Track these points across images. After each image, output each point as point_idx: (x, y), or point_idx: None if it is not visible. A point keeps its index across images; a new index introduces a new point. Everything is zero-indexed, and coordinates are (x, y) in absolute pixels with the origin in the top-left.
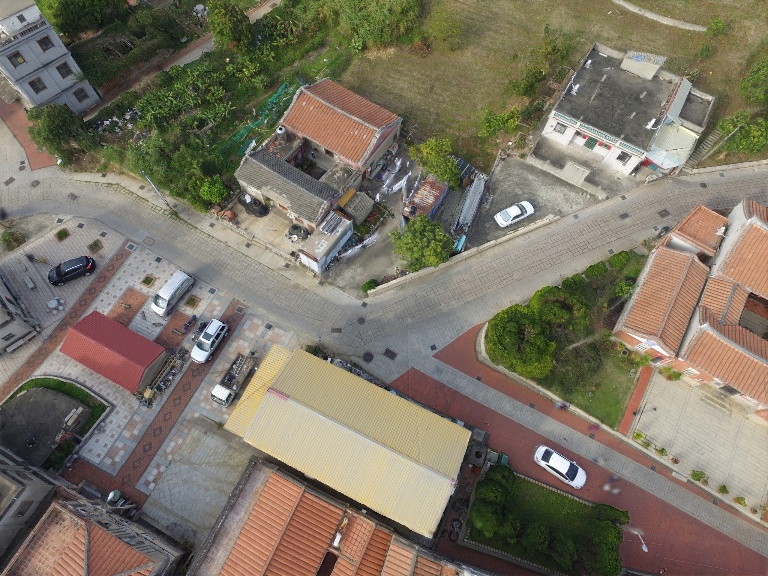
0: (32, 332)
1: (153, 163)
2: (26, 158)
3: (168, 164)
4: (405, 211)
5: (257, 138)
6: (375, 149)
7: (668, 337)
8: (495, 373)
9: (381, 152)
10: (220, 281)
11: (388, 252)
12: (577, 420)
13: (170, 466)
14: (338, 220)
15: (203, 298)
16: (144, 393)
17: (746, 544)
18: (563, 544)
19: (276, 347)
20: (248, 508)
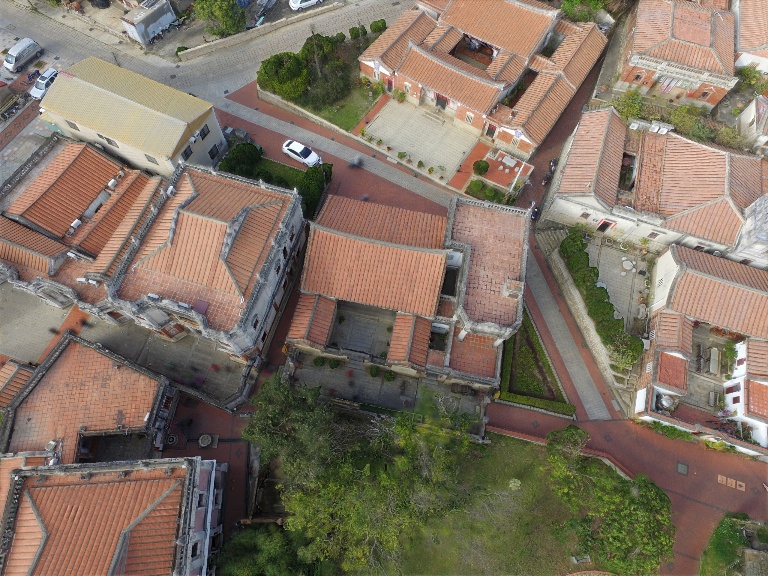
0: None
1: None
2: None
3: None
4: None
5: None
6: None
7: (389, 59)
8: (270, 105)
9: None
10: (64, 52)
11: (203, 32)
12: (324, 130)
13: (5, 163)
14: None
15: (49, 63)
16: None
17: (432, 199)
18: None
19: None
20: (48, 165)
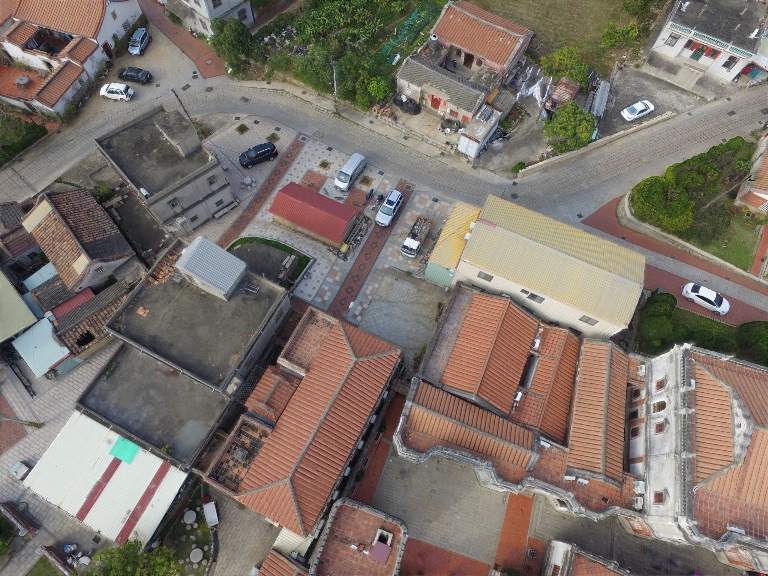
0: (234, 202)
1: (320, 68)
2: (197, 69)
3: None
4: (546, 105)
5: (400, 52)
6: (515, 55)
7: None
8: (637, 234)
9: (515, 61)
10: (387, 165)
11: (529, 143)
12: (713, 267)
13: (371, 304)
14: (491, 111)
15: (374, 178)
16: (341, 248)
17: None
18: (726, 342)
19: (460, 204)
20: (459, 320)
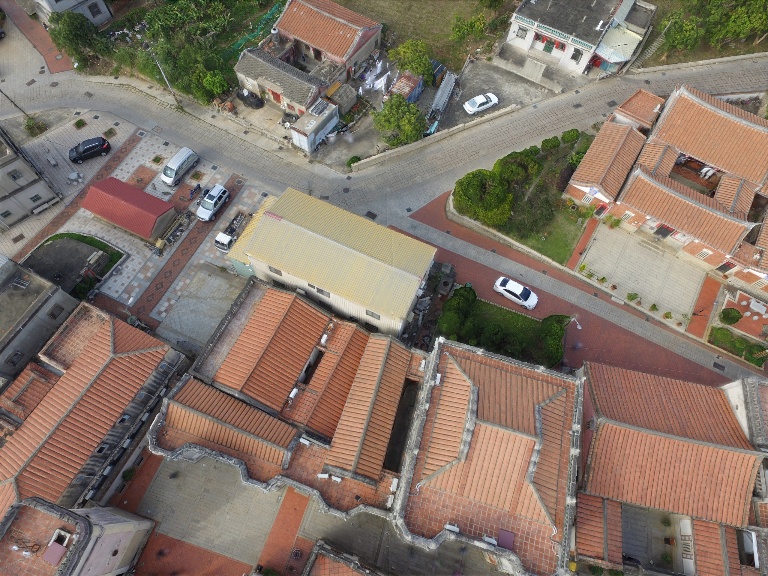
0: (56, 198)
1: (161, 62)
2: (45, 64)
3: (174, 64)
4: (384, 98)
5: (253, 47)
6: (358, 48)
7: (608, 186)
8: (462, 228)
9: (364, 55)
10: (221, 160)
11: (370, 137)
12: (532, 261)
13: (179, 300)
14: (325, 105)
15: (206, 173)
16: (156, 243)
17: (672, 350)
18: (514, 336)
19: (271, 197)
20: (248, 316)
